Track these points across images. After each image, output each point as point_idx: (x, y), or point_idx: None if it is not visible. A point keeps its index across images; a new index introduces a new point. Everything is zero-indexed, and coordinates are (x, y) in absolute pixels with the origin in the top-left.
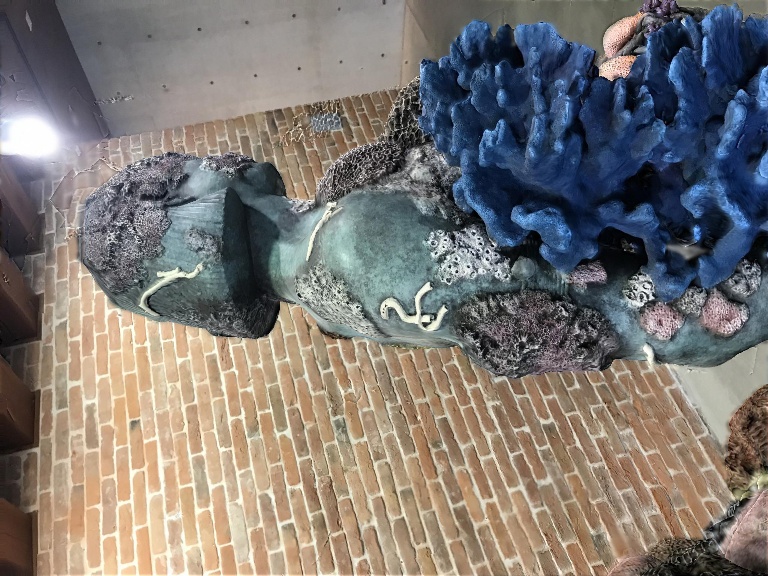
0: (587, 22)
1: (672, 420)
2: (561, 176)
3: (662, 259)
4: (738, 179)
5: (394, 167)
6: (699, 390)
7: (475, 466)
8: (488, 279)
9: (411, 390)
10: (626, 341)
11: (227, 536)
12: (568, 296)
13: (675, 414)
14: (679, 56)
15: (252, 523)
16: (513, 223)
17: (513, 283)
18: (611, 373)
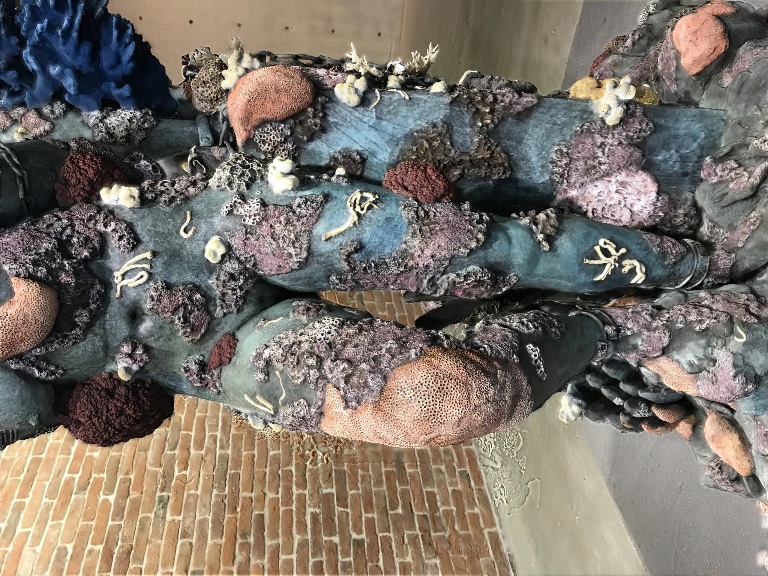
0: None
1: (481, 560)
2: None
3: (9, 91)
4: (50, 53)
5: None
6: (513, 535)
7: (273, 563)
8: None
9: (242, 484)
10: None
11: None
12: None
13: (485, 555)
14: None
15: (40, 571)
16: None
17: None
18: (436, 506)
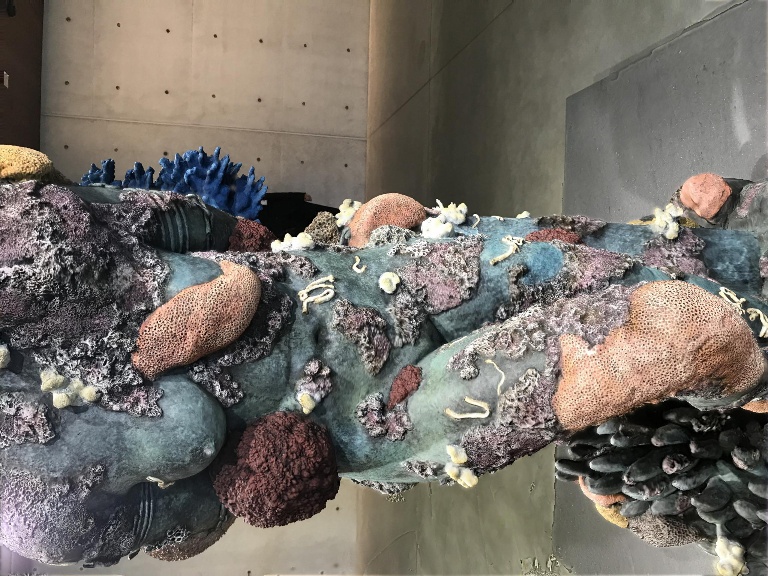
0: (465, 516)
1: None
2: None
3: None
4: None
5: None
6: None
7: None
8: None
9: None
10: None
11: None
12: None
13: None
14: None
15: None
16: None
17: None
18: None
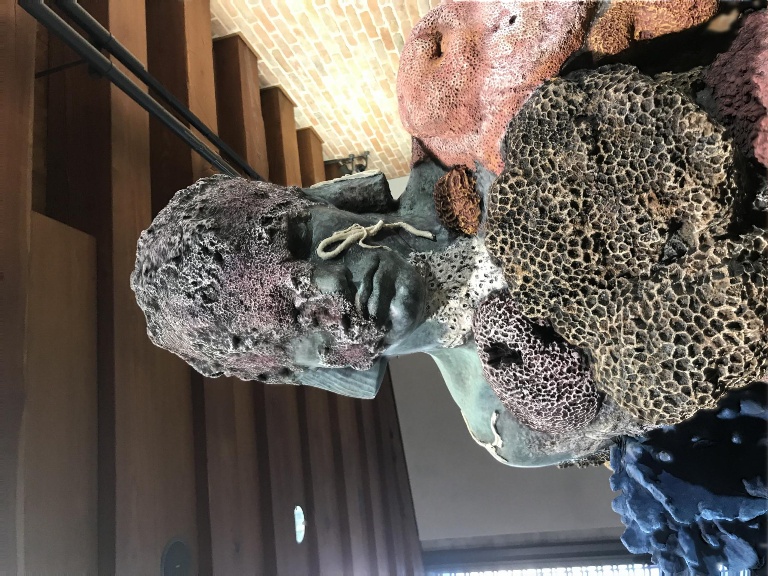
0: None
1: None
2: None
3: None
4: None
5: (574, 430)
6: None
7: None
8: None
9: None
10: None
11: None
12: None
13: None
14: None
15: None
16: None
17: None
18: None
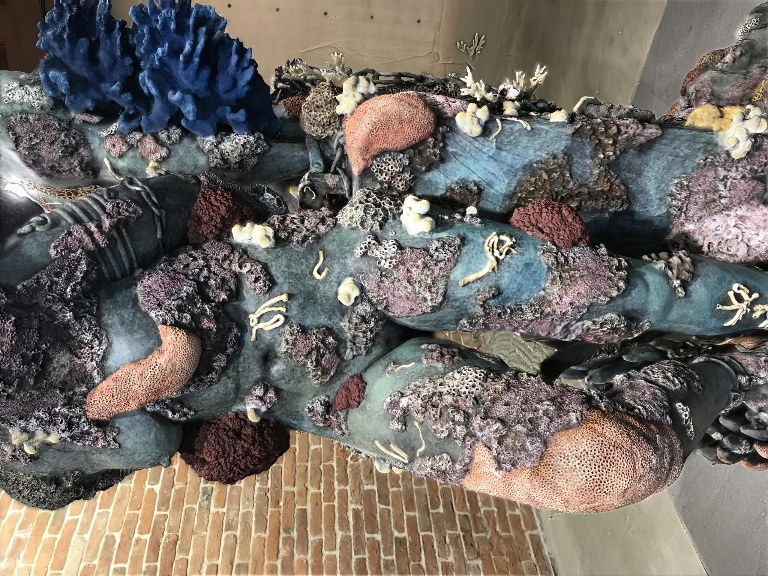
0: None
1: (523, 563)
2: (76, 59)
3: (124, 114)
4: (166, 76)
5: None
6: (555, 539)
7: (316, 559)
8: (29, 106)
9: (284, 478)
10: (96, 155)
11: (61, 564)
12: (68, 123)
13: (527, 557)
14: (136, 7)
15: (89, 559)
16: (51, 81)
17: (42, 111)
18: (477, 506)
